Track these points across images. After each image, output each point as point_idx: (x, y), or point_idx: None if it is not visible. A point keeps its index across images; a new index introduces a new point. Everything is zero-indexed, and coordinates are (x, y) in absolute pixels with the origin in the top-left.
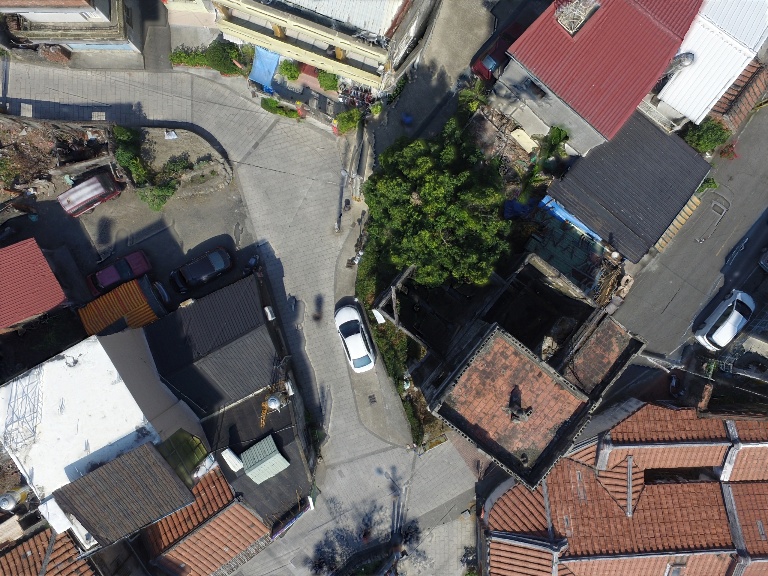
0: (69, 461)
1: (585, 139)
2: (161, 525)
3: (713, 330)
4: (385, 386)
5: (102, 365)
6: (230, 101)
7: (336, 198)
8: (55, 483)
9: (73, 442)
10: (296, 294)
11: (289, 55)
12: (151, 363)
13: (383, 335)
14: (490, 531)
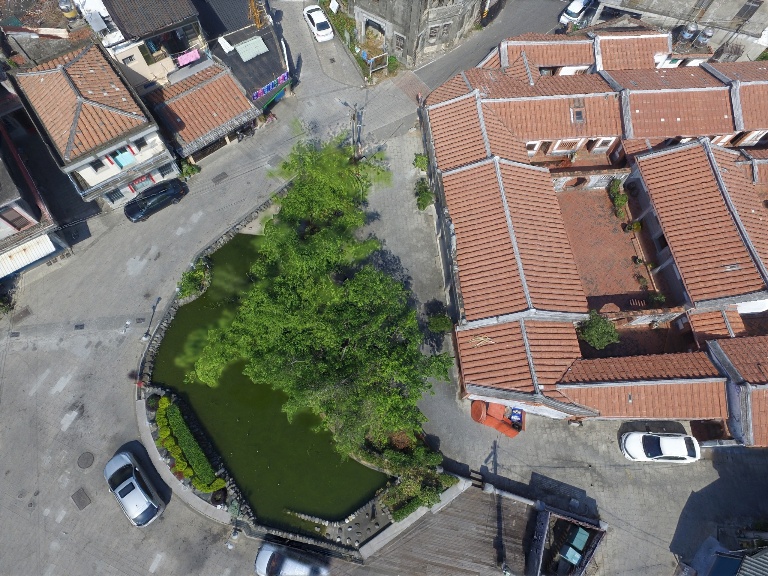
0: None
1: None
2: None
3: None
4: (342, 53)
5: None
6: None
7: None
8: (100, 7)
9: None
10: (277, 7)
11: None
12: None
13: None
14: None
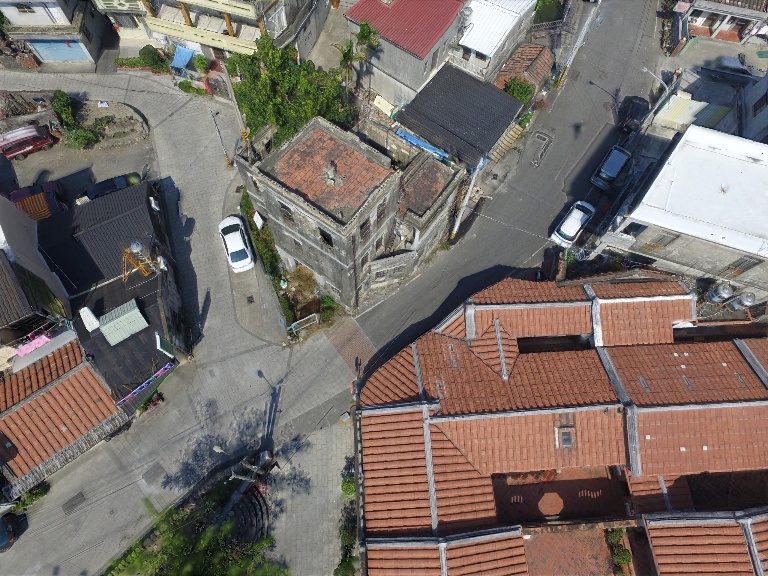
0: None
1: (412, 72)
2: None
3: (561, 225)
4: (264, 287)
5: None
6: (157, 89)
7: (232, 146)
8: None
9: None
10: (188, 213)
11: (197, 40)
12: (34, 237)
13: (263, 240)
14: (361, 407)
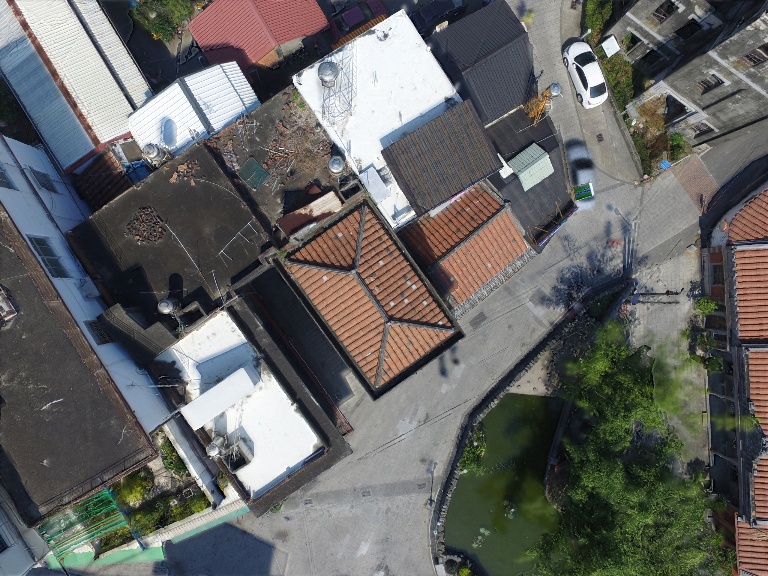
0: (384, 133)
1: None
2: (430, 241)
3: None
4: (612, 124)
5: (411, 38)
6: None
7: None
8: (371, 155)
9: (387, 114)
10: None
11: None
12: None
13: (611, 70)
14: (732, 242)
